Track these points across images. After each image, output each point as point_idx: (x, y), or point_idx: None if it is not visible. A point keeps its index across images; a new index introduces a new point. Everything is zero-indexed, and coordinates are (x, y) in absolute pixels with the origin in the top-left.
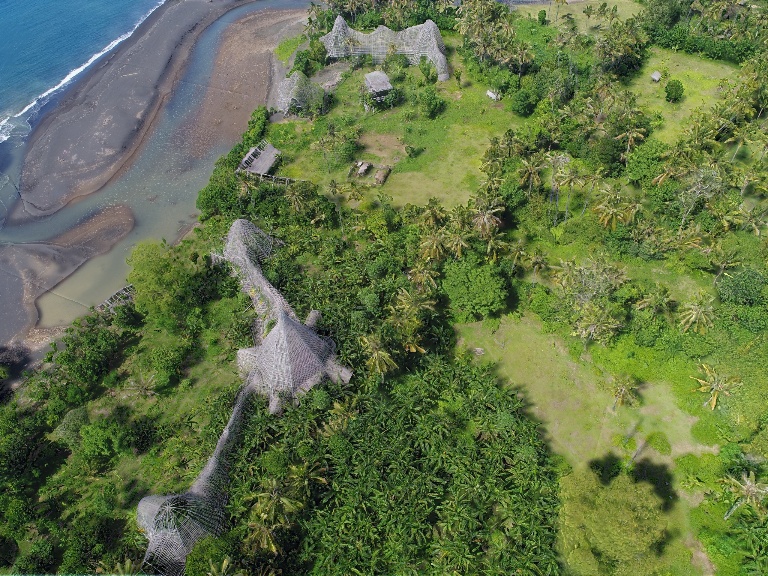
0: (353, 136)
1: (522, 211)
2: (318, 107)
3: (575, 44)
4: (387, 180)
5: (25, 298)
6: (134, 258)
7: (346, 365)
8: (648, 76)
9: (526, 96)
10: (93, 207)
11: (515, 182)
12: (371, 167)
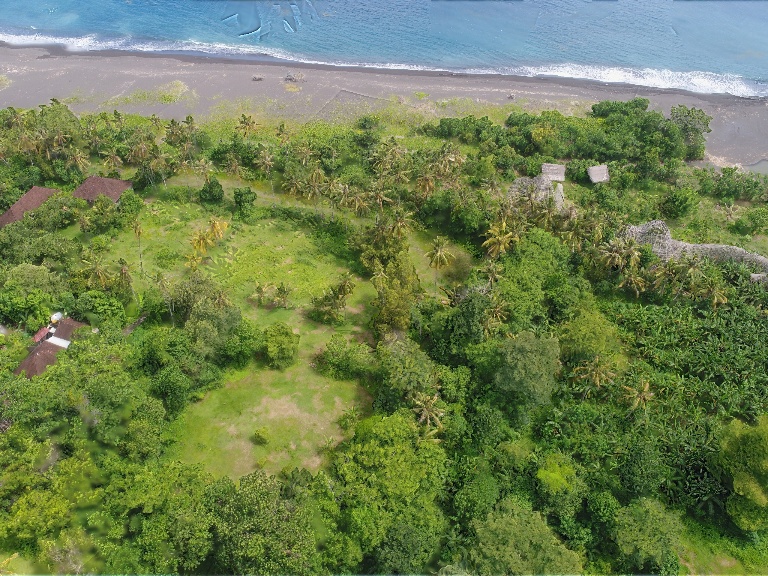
0: None
1: None
2: None
3: None
4: None
5: (762, 154)
6: None
7: None
8: None
9: None
10: None
11: None
12: None
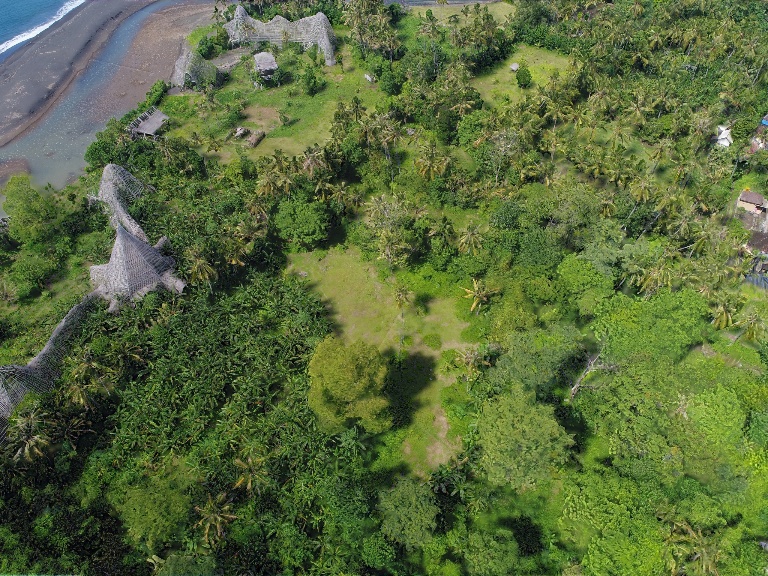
0: (239, 108)
1: (364, 167)
2: (211, 82)
3: (432, 32)
4: (260, 143)
5: None
6: (7, 189)
7: (182, 278)
8: (509, 67)
9: (392, 77)
10: None
11: (353, 140)
12: (248, 133)
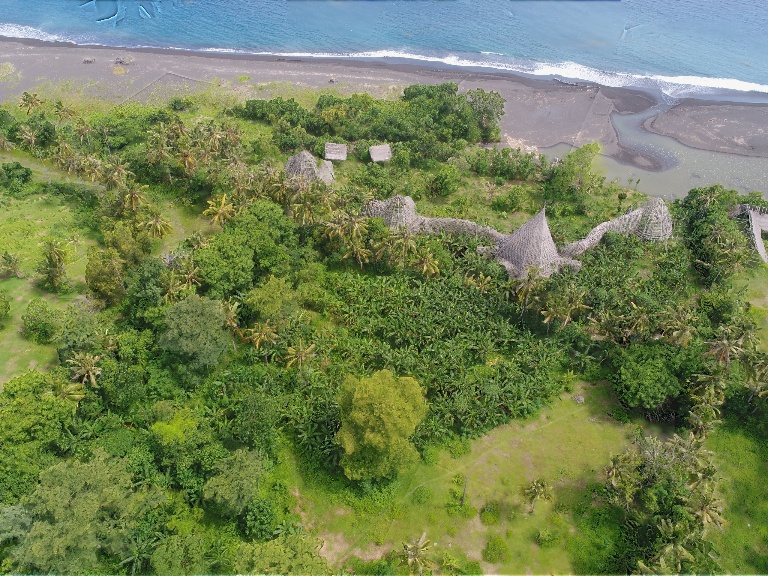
0: None
1: None
2: None
3: None
4: None
5: (562, 137)
6: None
7: None
8: None
9: None
10: (668, 148)
11: None
12: None
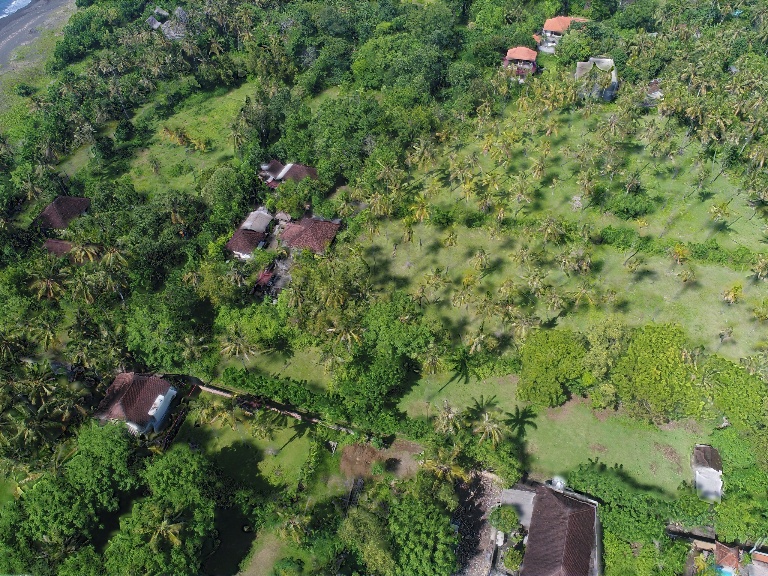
0: None
1: None
2: None
3: None
4: None
5: None
6: None
7: None
8: None
9: None
10: None
11: None
12: None
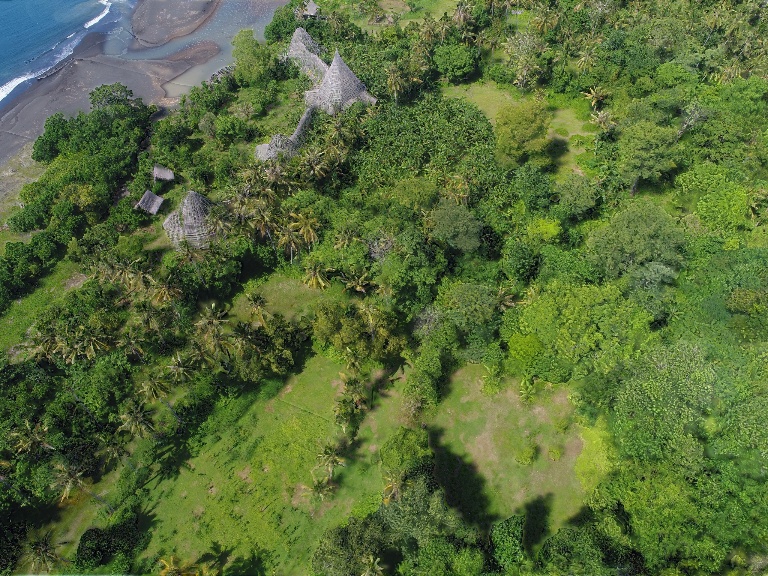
0: (371, 1)
1: (487, 30)
2: None
3: None
4: None
5: (154, 84)
6: (236, 40)
7: (373, 96)
8: None
9: None
10: (188, 42)
11: (482, 6)
12: (384, 17)
